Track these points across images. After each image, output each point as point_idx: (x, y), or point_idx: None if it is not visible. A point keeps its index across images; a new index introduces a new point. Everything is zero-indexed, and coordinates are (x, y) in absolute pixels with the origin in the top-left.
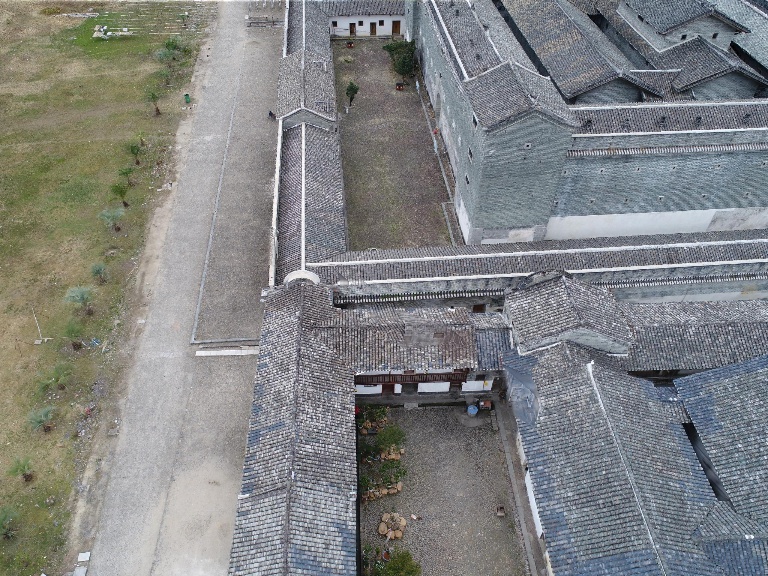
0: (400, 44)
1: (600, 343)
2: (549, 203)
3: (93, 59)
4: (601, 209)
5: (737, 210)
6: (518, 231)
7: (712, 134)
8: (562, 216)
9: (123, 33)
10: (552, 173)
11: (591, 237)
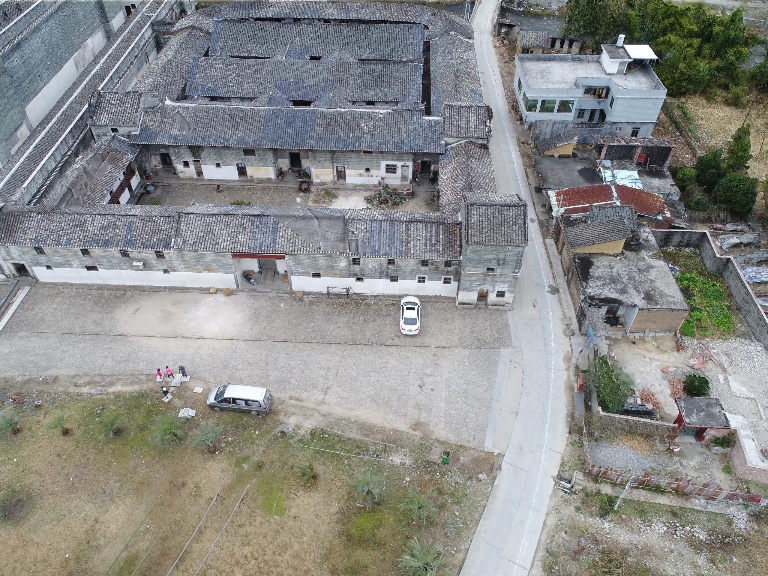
0: None
1: (151, 102)
2: (17, 98)
3: None
4: (35, 90)
5: (78, 53)
6: (20, 131)
7: (36, 7)
8: (24, 108)
9: None
10: (3, 73)
11: (45, 115)
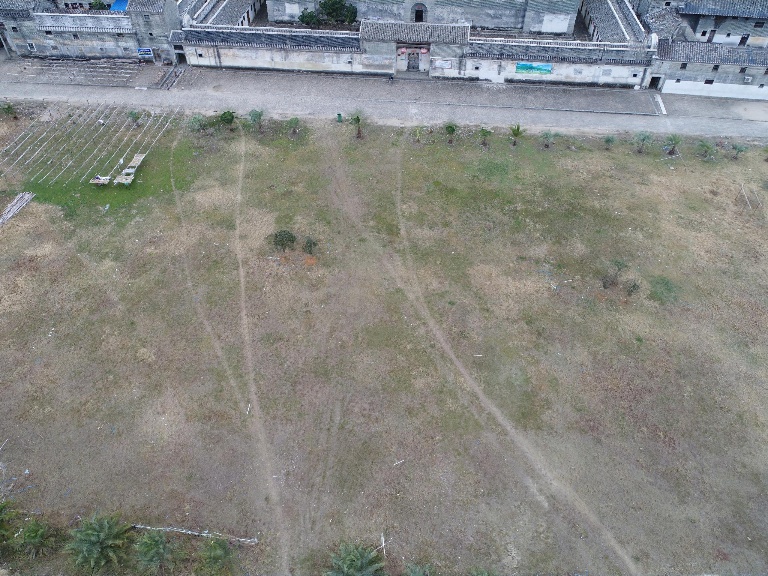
0: (335, 2)
1: None
2: None
3: (191, 186)
4: None
5: None
6: None
7: None
8: None
9: (138, 160)
10: None
11: None
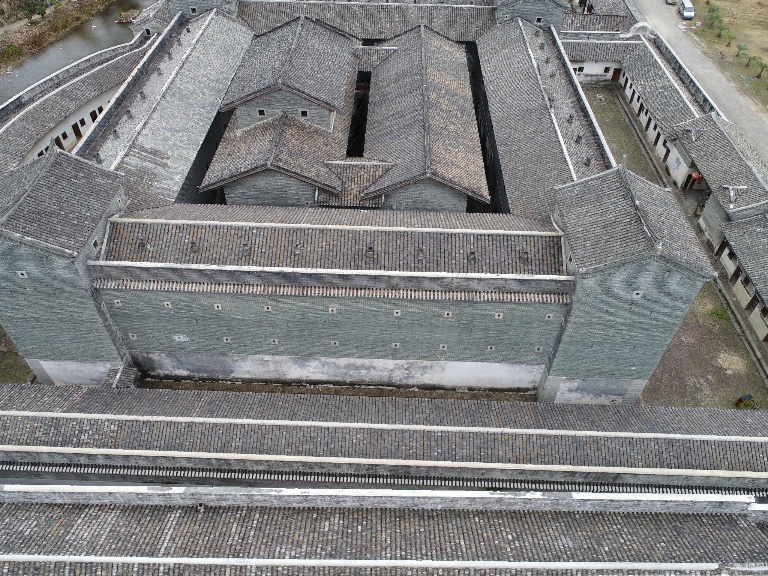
0: None
1: None
2: None
3: None
4: None
5: None
6: None
7: None
8: None
9: None
10: None
11: None
